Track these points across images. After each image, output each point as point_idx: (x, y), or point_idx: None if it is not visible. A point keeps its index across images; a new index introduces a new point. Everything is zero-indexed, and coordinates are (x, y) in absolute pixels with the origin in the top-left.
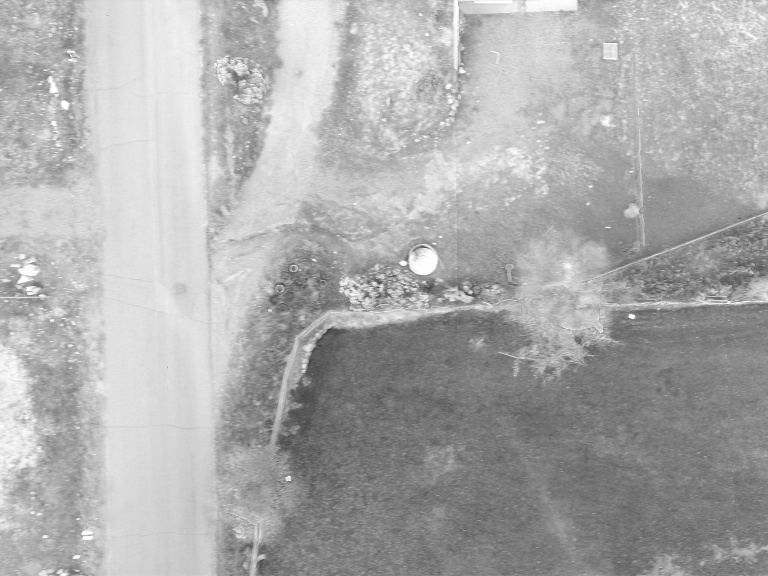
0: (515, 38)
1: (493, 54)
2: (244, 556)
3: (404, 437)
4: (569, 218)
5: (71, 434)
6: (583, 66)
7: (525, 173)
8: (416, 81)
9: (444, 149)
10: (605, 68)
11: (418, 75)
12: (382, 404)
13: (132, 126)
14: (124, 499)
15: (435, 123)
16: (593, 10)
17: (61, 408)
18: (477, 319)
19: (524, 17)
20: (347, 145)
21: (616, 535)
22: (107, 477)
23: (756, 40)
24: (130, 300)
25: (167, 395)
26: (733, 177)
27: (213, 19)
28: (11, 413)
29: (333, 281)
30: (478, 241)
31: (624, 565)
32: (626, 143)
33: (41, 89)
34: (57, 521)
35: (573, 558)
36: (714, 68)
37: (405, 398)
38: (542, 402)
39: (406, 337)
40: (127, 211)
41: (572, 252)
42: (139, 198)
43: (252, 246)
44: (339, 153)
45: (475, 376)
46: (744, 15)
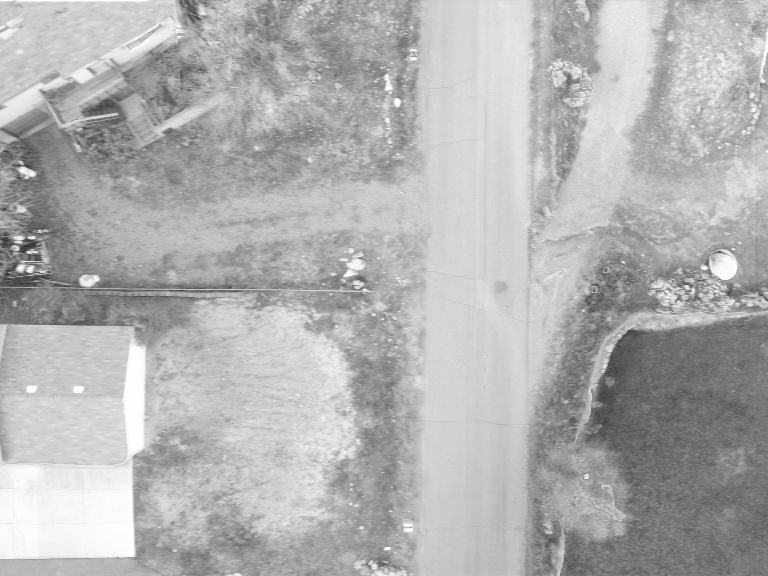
0: None
1: None
2: (549, 551)
3: (697, 438)
4: None
5: (387, 427)
6: None
7: None
8: (725, 89)
9: (744, 157)
10: None
11: (727, 83)
12: (677, 405)
13: (462, 125)
14: (438, 492)
15: (737, 131)
16: None
17: (379, 401)
18: None
19: None
20: (657, 150)
21: None
22: (422, 470)
23: None
24: (452, 297)
25: (483, 391)
26: None
27: (545, 22)
28: (333, 405)
29: (638, 283)
30: None
31: None
32: None
33: (377, 86)
34: (371, 513)
35: None
36: None
37: (699, 400)
38: None
39: (701, 340)
40: (453, 209)
41: None
42: (465, 196)
43: (569, 247)
44: (649, 158)
45: (766, 380)
46: None
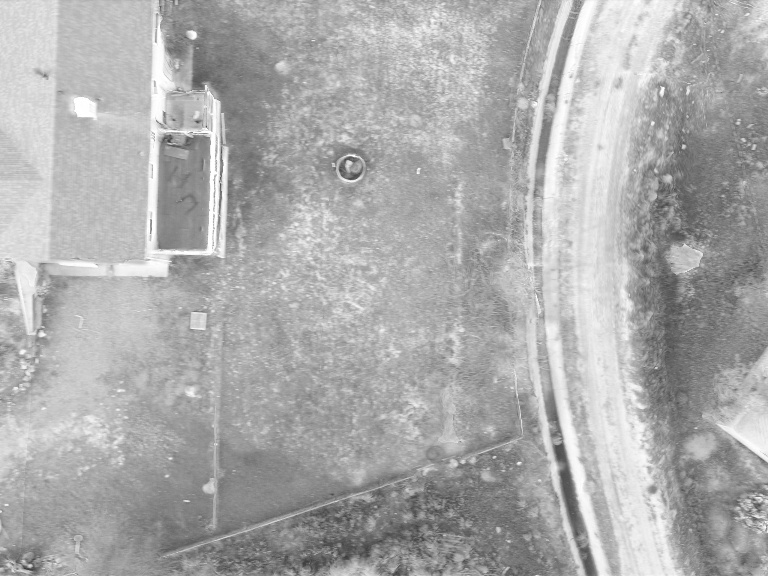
0: (100, 302)
1: (76, 318)
2: None
3: None
4: (145, 490)
5: None
6: (169, 335)
7: (101, 442)
8: None
9: (17, 414)
10: (192, 338)
11: None
12: None
13: None
14: None
15: (8, 388)
16: (184, 277)
17: None
18: None
19: (111, 281)
20: None
21: None
22: None
23: (362, 311)
24: None
25: None
26: (327, 452)
27: None
28: None
29: None
30: (46, 511)
31: None
32: (212, 415)
33: None
34: None
35: None
36: (313, 339)
37: None
38: None
39: None
40: None
41: (145, 526)
42: None
43: None
44: None
45: None
46: (351, 284)
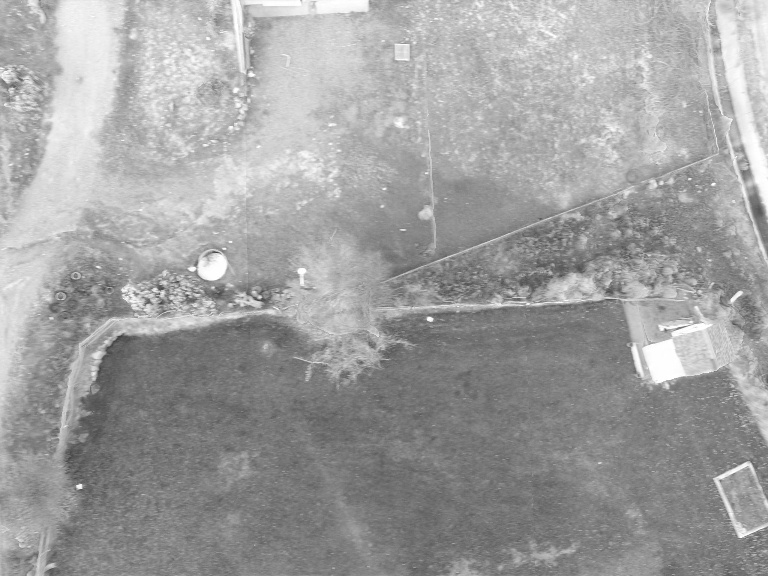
0: (305, 40)
1: (283, 57)
2: (31, 565)
3: (197, 444)
4: (362, 221)
5: None
6: (375, 68)
7: (317, 176)
8: None
9: (234, 153)
10: (397, 69)
11: (202, 79)
12: (175, 411)
13: None
14: None
15: (223, 127)
16: (385, 11)
17: None
18: (270, 324)
19: (314, 19)
20: (131, 151)
21: (412, 540)
22: None
23: (556, 38)
24: None
25: None
26: (533, 177)
27: None
28: None
29: (120, 288)
30: (269, 245)
31: (420, 570)
32: (421, 144)
33: None
34: None
35: (368, 564)
36: (512, 67)
37: (198, 404)
38: (338, 407)
39: (198, 343)
40: None
41: (365, 255)
42: None
43: (32, 254)
44: (123, 159)
45: (270, 381)
46: (543, 13)
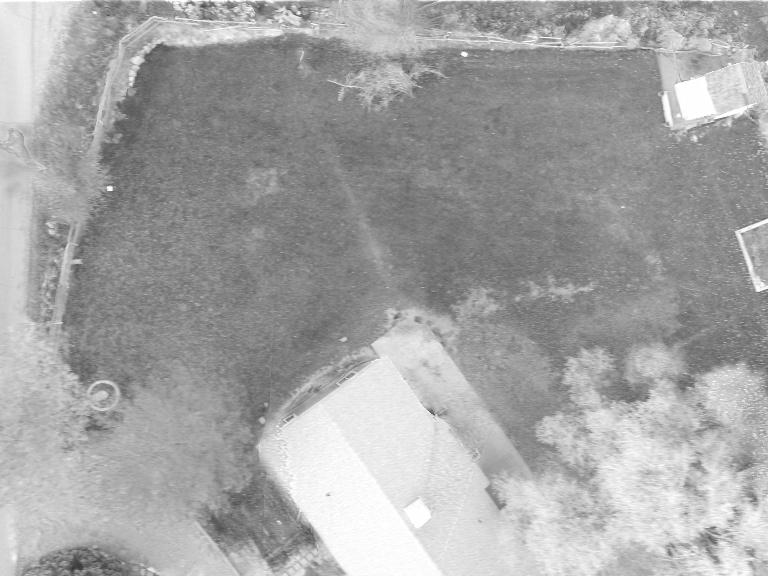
0: None
1: None
2: (58, 256)
3: (228, 157)
4: None
5: None
6: None
7: None
8: None
9: None
10: None
11: None
12: (208, 123)
13: None
14: None
15: None
16: None
17: None
18: (307, 45)
19: None
20: None
21: (432, 265)
22: None
23: None
24: None
25: None
26: None
27: None
28: None
29: None
30: None
31: (438, 294)
32: None
33: None
34: None
35: (388, 284)
36: None
37: (231, 118)
38: (368, 132)
39: (235, 58)
40: None
41: None
42: None
43: None
44: None
45: (302, 102)
46: None
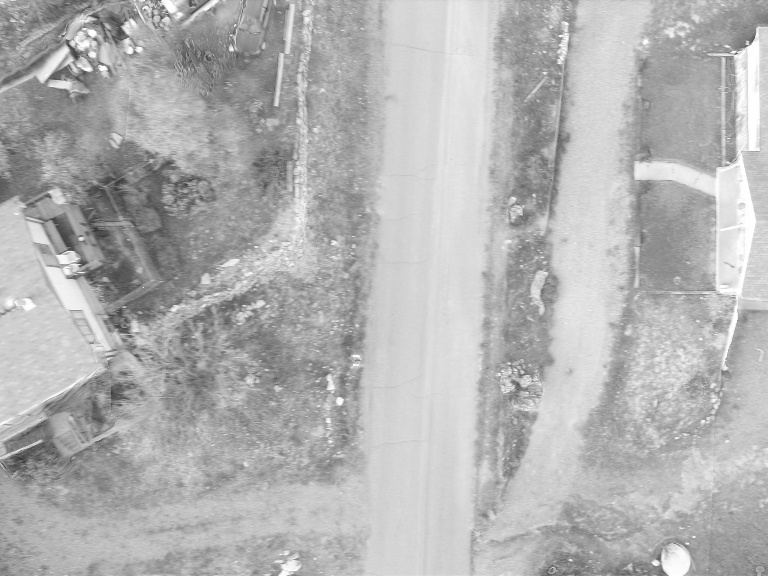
0: None
1: (757, 351)
2: None
3: None
4: None
5: None
6: None
7: None
8: (684, 383)
9: (702, 447)
10: None
11: (687, 377)
12: None
13: (406, 426)
14: None
15: (696, 421)
16: None
17: None
18: None
19: None
20: (610, 444)
21: None
22: None
23: None
24: None
25: None
26: None
27: (495, 323)
28: None
29: None
30: (731, 542)
31: None
32: None
33: (318, 386)
34: None
35: None
36: None
37: None
38: None
39: None
40: (394, 510)
41: None
42: (407, 498)
43: (514, 548)
44: (602, 452)
45: None
46: None
